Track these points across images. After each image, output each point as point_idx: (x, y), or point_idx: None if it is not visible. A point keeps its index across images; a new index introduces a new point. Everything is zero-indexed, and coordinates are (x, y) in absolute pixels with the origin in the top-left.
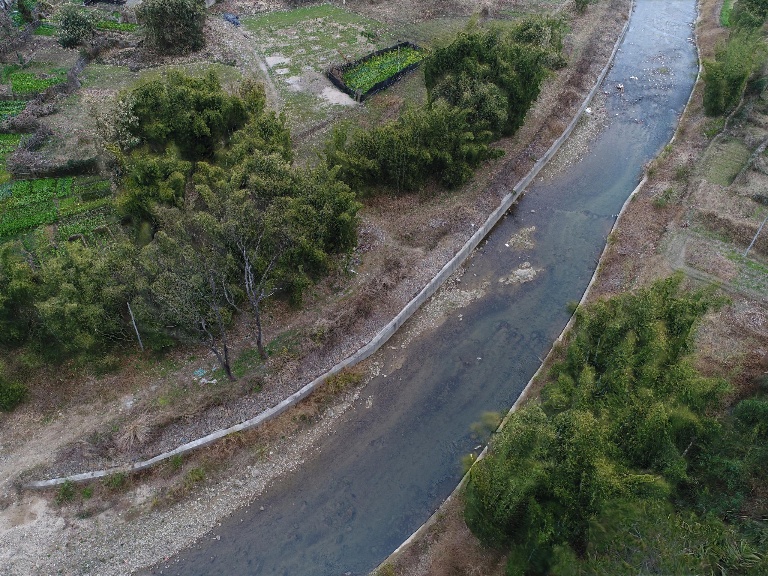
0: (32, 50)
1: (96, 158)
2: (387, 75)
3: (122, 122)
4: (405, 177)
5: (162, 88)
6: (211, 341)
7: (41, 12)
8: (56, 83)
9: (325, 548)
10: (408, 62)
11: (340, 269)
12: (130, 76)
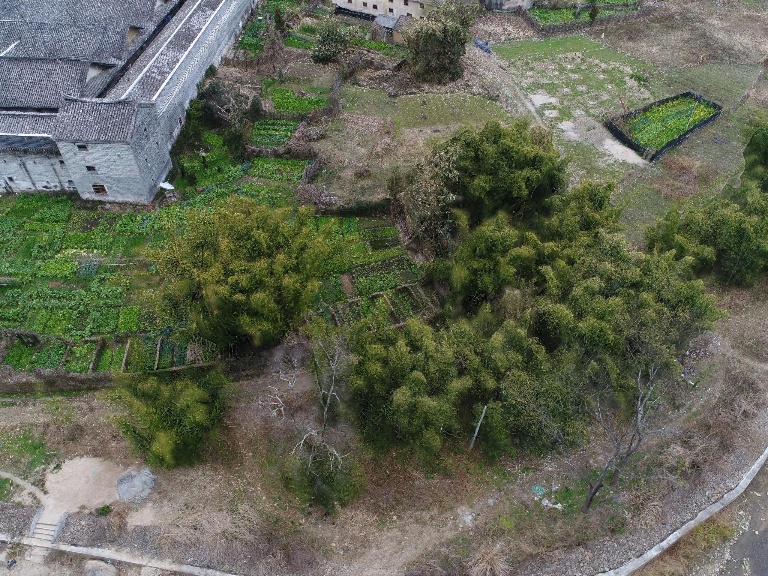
0: (285, 63)
1: (385, 202)
2: (674, 131)
3: (441, 175)
4: (743, 271)
5: (482, 140)
6: None
7: (289, 22)
8: (316, 103)
9: None
10: (696, 117)
11: (678, 379)
12: (390, 103)
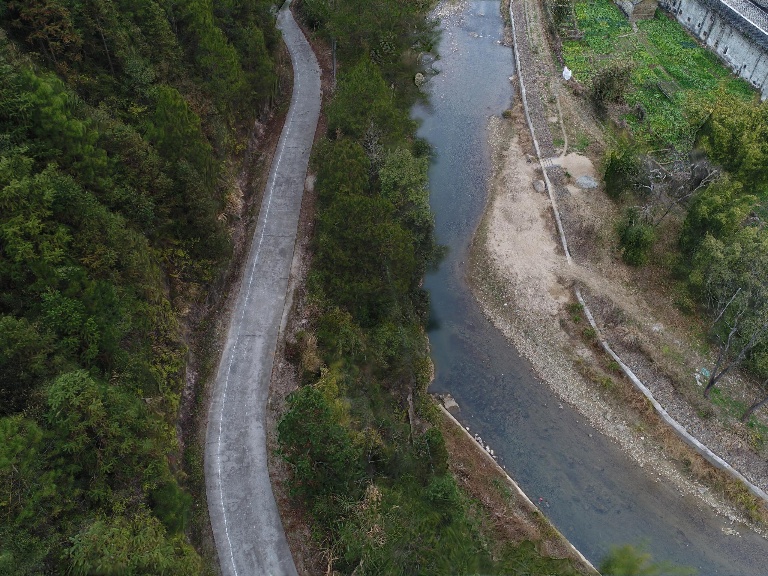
0: None
1: None
2: None
3: None
4: None
5: None
6: (744, 376)
7: None
8: None
9: (566, 487)
10: None
11: None
12: None
